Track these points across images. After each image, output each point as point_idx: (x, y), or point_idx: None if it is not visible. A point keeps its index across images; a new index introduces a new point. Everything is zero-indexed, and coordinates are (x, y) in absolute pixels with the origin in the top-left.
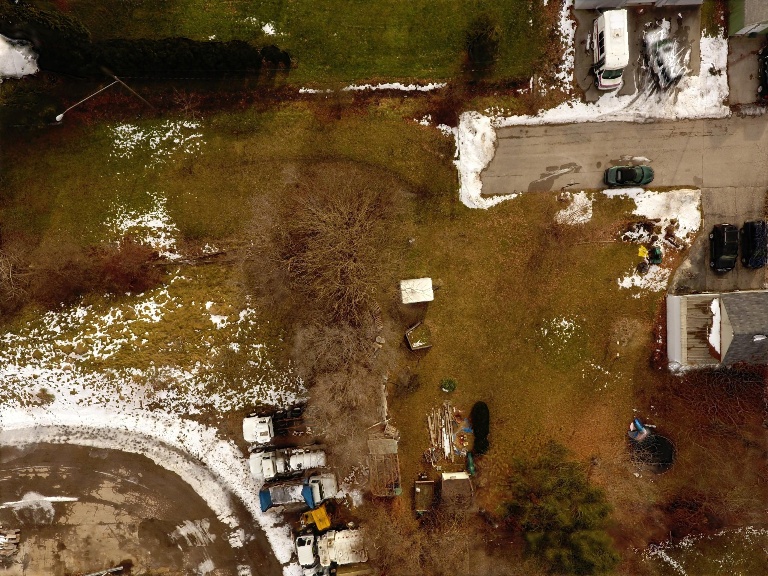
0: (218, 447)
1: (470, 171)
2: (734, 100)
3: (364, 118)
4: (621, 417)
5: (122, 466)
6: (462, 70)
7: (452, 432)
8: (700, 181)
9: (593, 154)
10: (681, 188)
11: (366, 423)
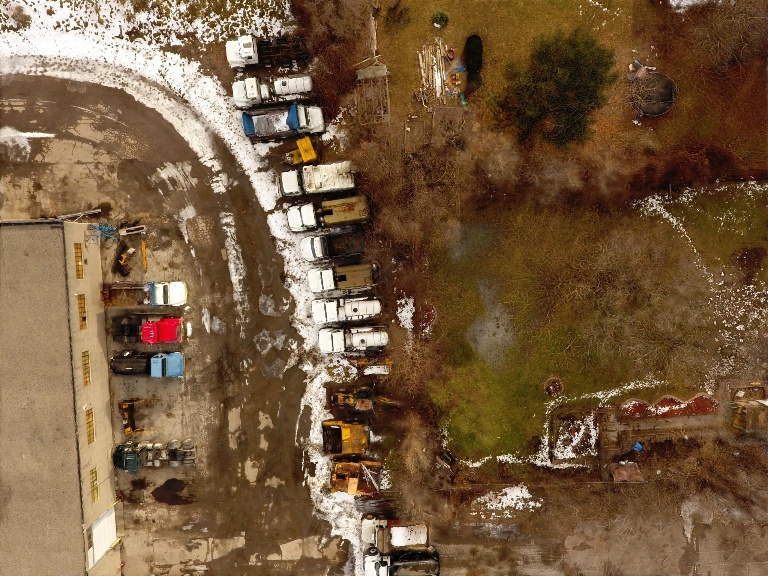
0: (201, 82)
1: None
2: None
3: None
4: (620, 58)
5: (101, 101)
6: None
7: (444, 69)
8: None
9: None
10: None
11: (354, 59)
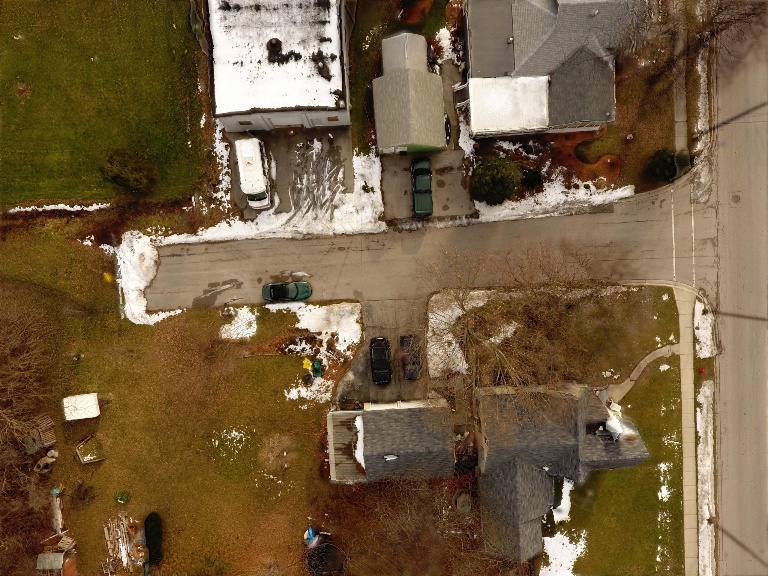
0: None
1: (131, 290)
2: (390, 215)
3: (28, 239)
4: (297, 525)
5: None
6: (124, 191)
7: (128, 543)
8: (360, 294)
9: (253, 270)
10: (342, 301)
11: (43, 535)
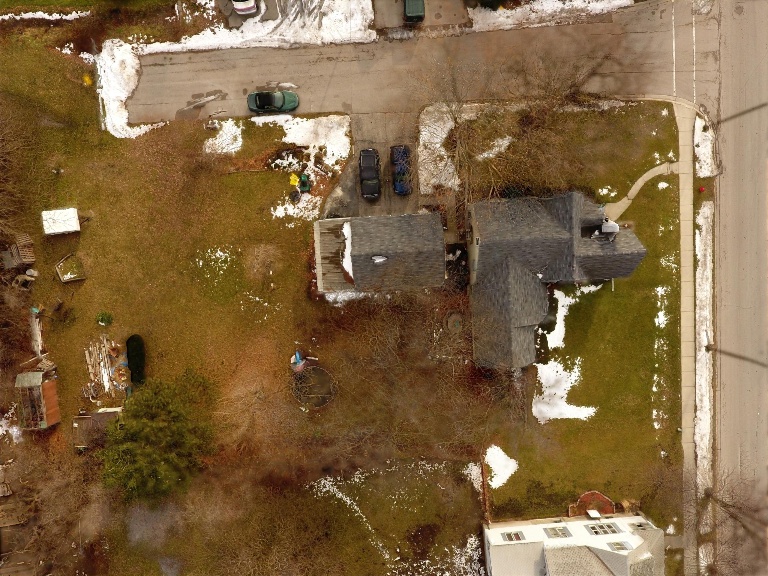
0: None
1: (112, 99)
2: (380, 24)
3: (5, 47)
4: (283, 350)
5: None
6: None
7: (110, 366)
8: (349, 107)
9: (238, 81)
10: (330, 114)
11: (22, 358)
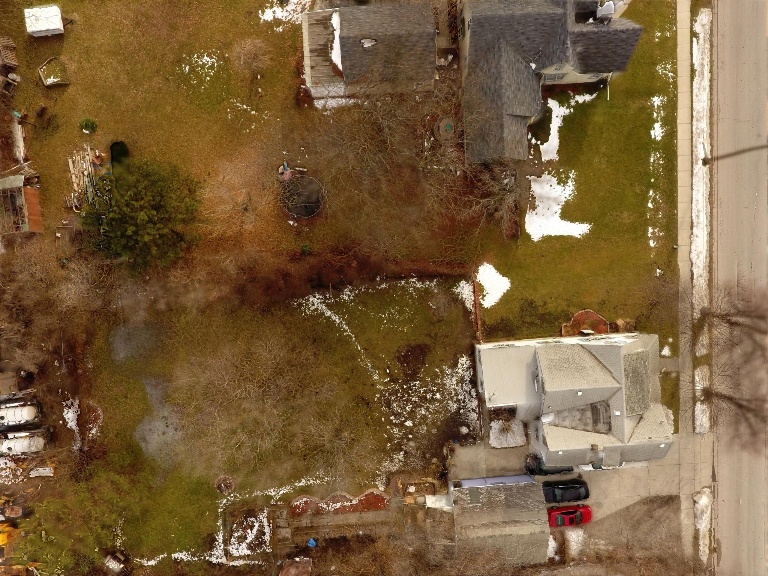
0: None
1: None
2: None
3: None
4: (271, 160)
5: None
6: None
7: (93, 175)
8: None
9: None
10: None
11: (4, 166)
